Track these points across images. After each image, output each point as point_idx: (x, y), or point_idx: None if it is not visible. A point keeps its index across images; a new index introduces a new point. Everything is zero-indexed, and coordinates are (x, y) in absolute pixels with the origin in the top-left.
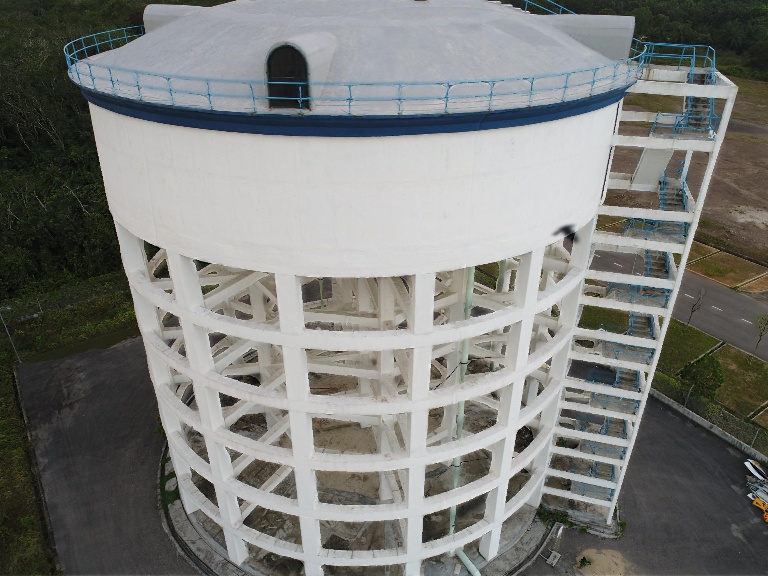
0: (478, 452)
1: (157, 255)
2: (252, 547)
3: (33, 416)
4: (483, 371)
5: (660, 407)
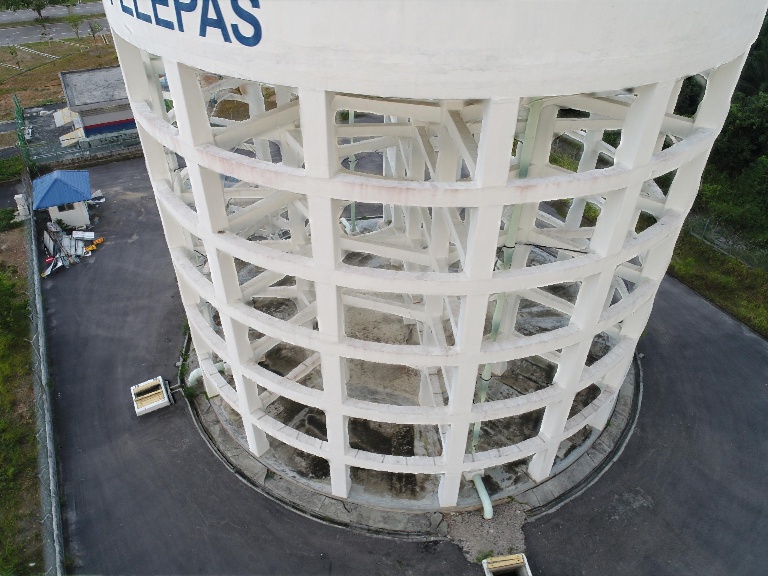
0: None
1: None
2: None
3: None
4: None
5: (55, 331)
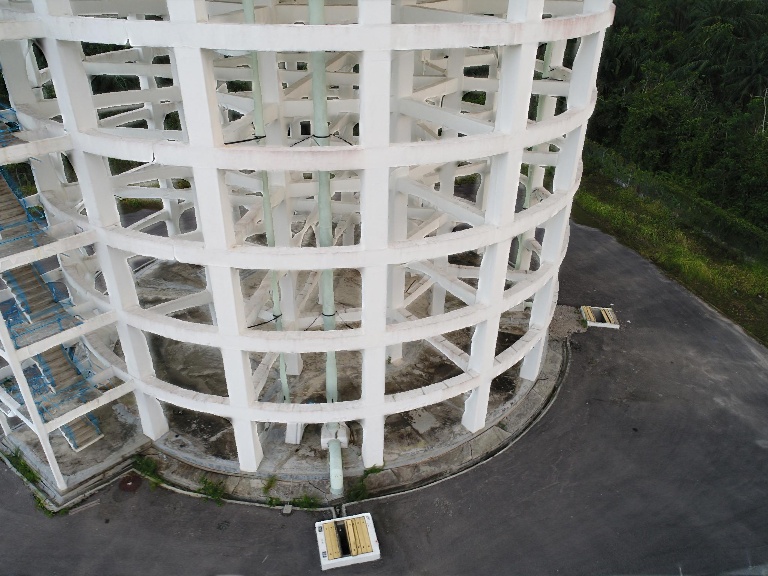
0: (213, 369)
1: None
2: None
3: (460, 187)
4: None
5: None
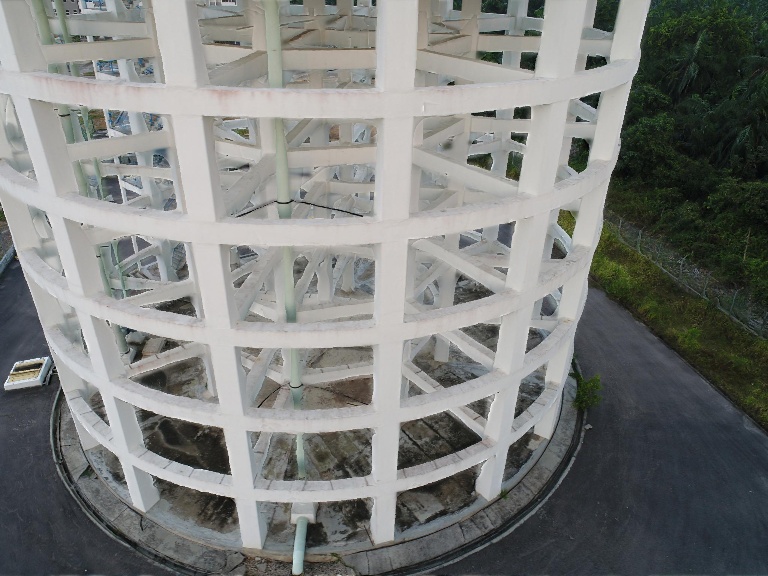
0: None
1: None
2: (473, 286)
3: None
4: None
5: None
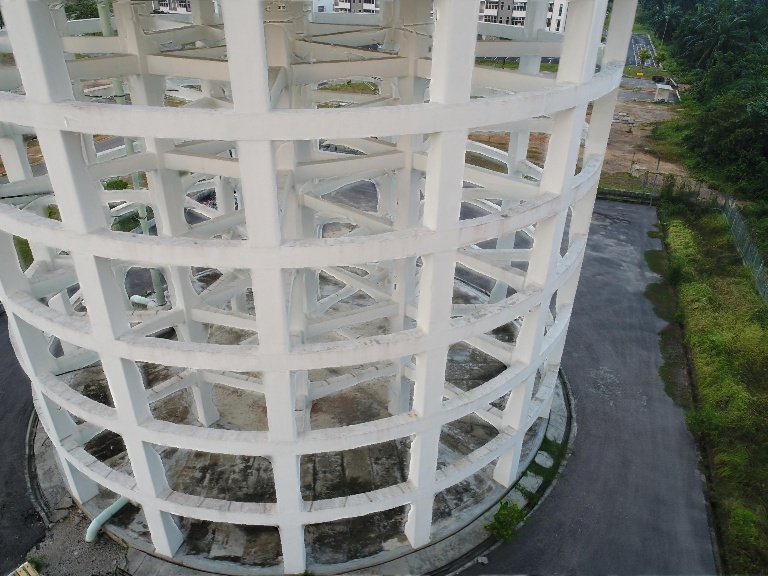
0: None
1: (490, 218)
2: None
3: None
4: None
5: None
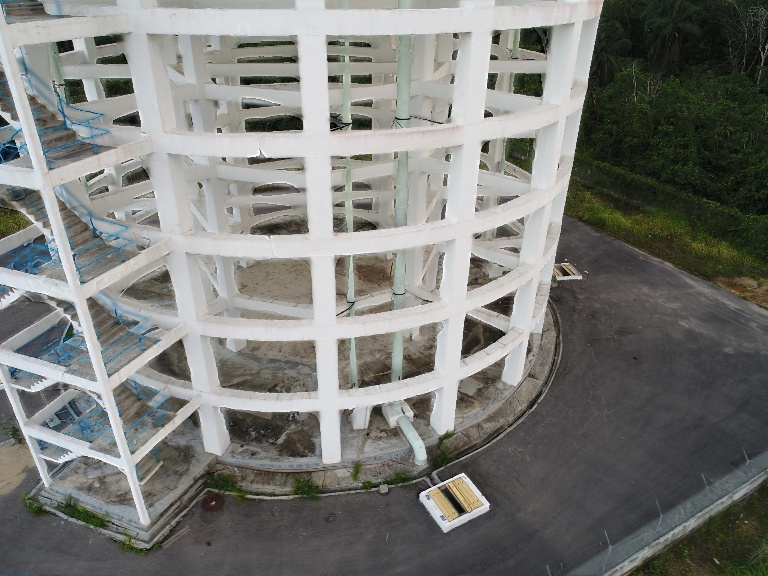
0: (242, 377)
1: None
2: None
3: None
4: (426, 412)
5: None
